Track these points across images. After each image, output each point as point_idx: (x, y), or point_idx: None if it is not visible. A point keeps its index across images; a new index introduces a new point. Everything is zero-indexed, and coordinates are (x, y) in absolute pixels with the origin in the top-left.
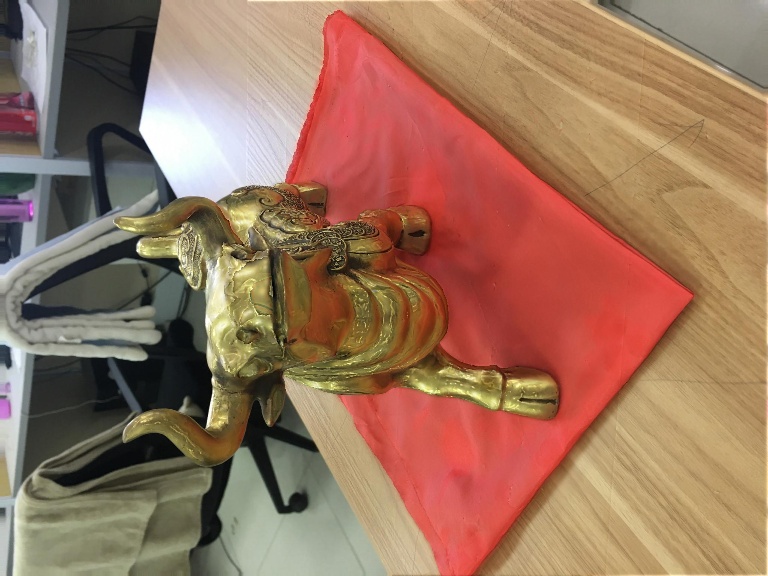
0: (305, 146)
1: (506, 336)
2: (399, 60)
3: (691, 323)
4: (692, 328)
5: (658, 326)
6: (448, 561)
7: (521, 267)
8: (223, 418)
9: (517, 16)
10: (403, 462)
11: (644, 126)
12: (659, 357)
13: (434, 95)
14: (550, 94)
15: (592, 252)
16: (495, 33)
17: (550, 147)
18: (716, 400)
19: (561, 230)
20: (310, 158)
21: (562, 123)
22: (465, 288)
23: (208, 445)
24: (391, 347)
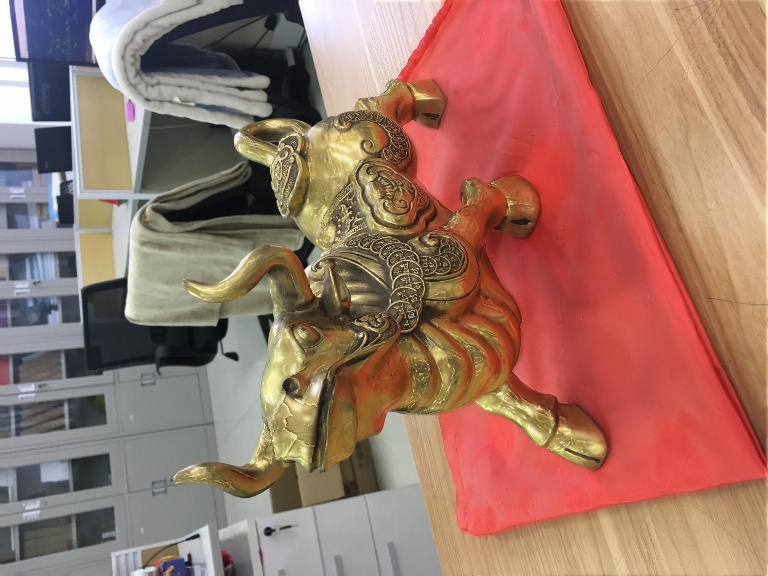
0: (435, 37)
1: (576, 371)
2: (560, 6)
3: (757, 491)
4: (756, 495)
5: (721, 478)
6: (465, 514)
7: (613, 322)
8: (268, 458)
9: (716, 35)
10: None
11: None
12: (712, 495)
13: (584, 84)
14: (716, 160)
15: (687, 369)
16: (682, 39)
17: (691, 220)
18: (748, 567)
19: (665, 324)
20: (437, 54)
21: (715, 203)
22: (553, 300)
23: (249, 486)
24: (444, 406)
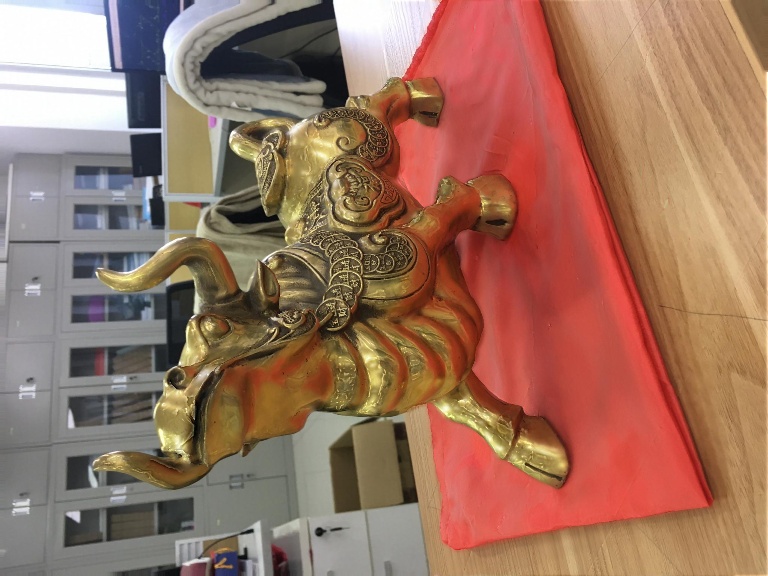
0: (435, 33)
1: (545, 382)
2: None
3: (701, 521)
4: (700, 527)
5: (664, 505)
6: (447, 526)
7: (575, 330)
8: None
9: (671, 18)
10: (442, 414)
11: (748, 278)
12: (660, 523)
13: (549, 75)
14: (669, 155)
15: (633, 382)
16: (641, 24)
17: (646, 221)
18: None
19: (615, 333)
20: (437, 50)
21: (668, 202)
22: (526, 306)
23: (173, 478)
24: (380, 409)
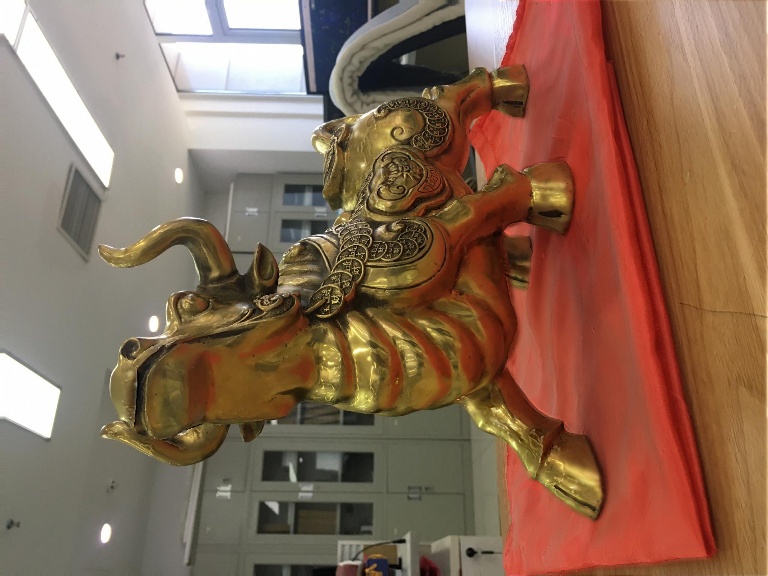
0: (523, 16)
1: (589, 395)
2: None
3: (708, 575)
4: None
5: (666, 548)
6: (508, 551)
7: (610, 334)
8: (198, 430)
9: None
10: None
11: (756, 263)
12: (674, 572)
13: (587, 40)
14: (691, 117)
15: (643, 395)
16: None
17: (671, 200)
18: None
19: None
20: (525, 35)
21: (689, 174)
22: (577, 308)
23: (175, 454)
24: (377, 406)
